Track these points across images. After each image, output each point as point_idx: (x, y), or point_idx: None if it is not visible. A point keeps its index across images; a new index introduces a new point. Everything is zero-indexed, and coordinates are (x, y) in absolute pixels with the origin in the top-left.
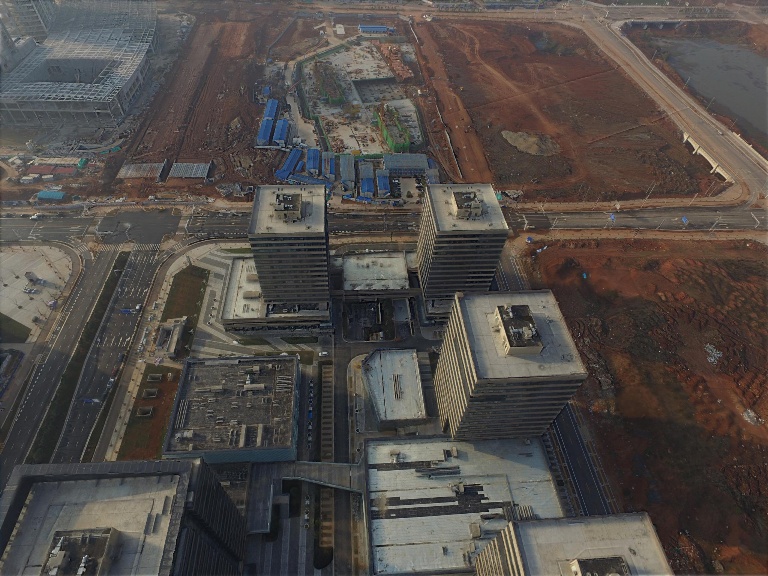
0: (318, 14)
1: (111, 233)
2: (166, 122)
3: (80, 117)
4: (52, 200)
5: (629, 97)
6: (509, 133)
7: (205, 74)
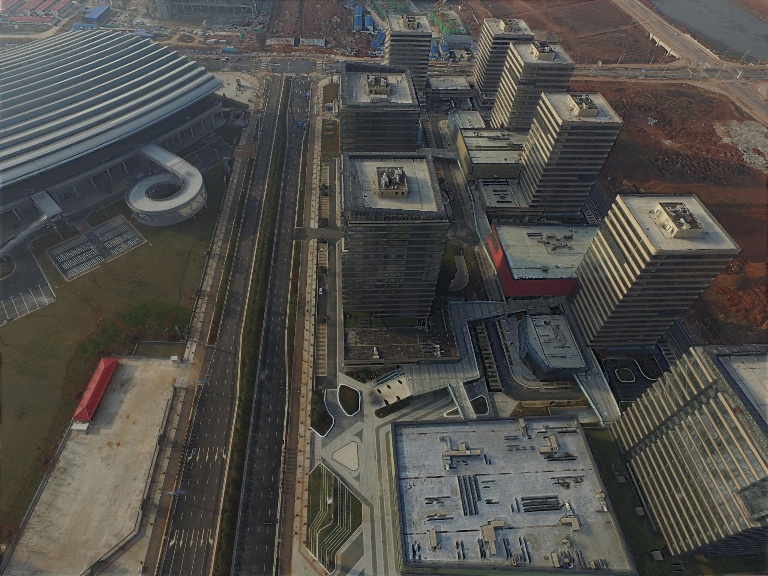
0: None
1: None
2: (286, 18)
3: (227, 13)
4: (231, 52)
5: (613, 14)
6: None
7: None
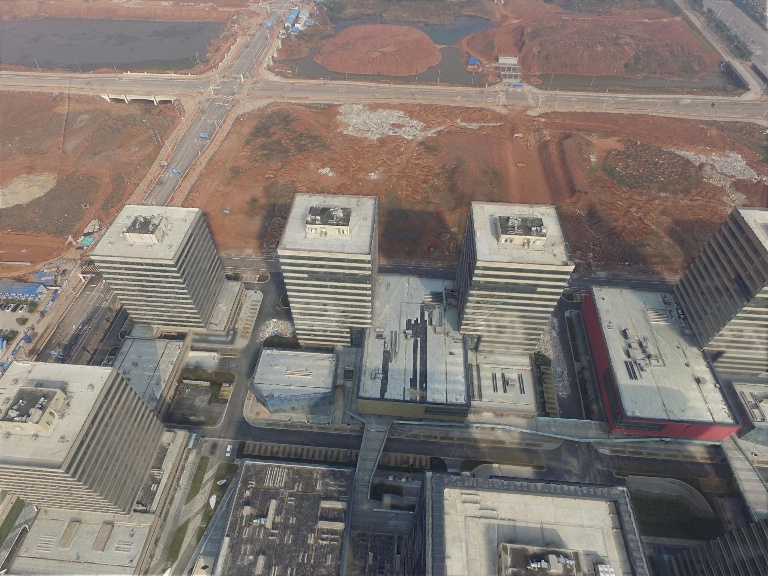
0: None
1: None
2: None
3: None
4: None
5: (17, 103)
6: None
7: None
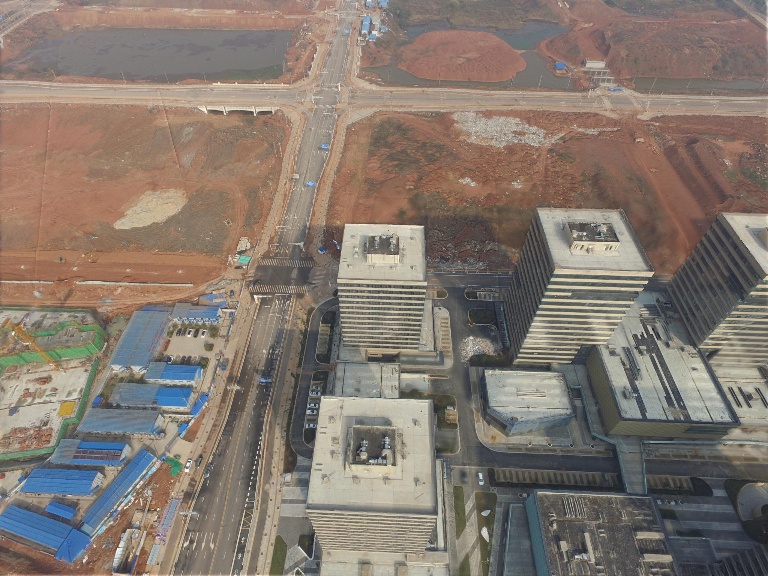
0: None
1: None
2: None
3: None
4: None
5: (113, 117)
6: (123, 222)
7: None
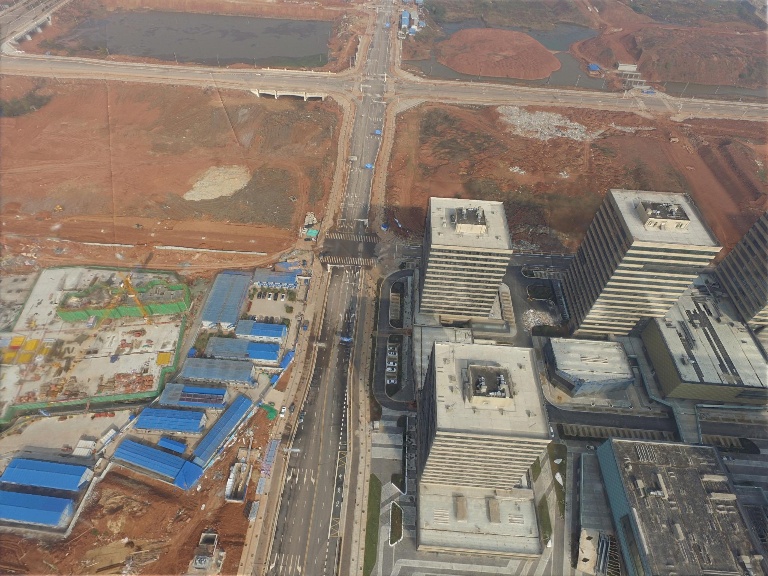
0: None
1: None
2: None
3: None
4: None
5: (169, 96)
6: (193, 194)
7: None
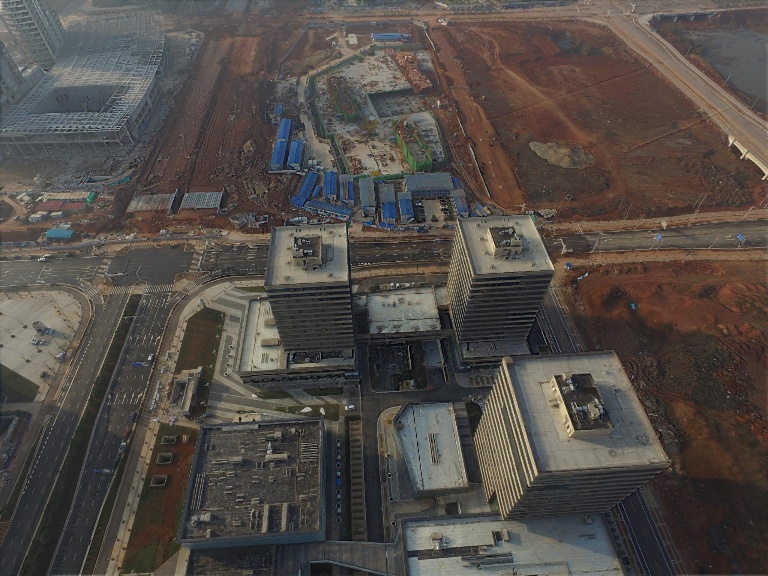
0: (329, 24)
1: (121, 274)
2: (177, 148)
3: (89, 147)
4: (61, 239)
5: (664, 98)
6: (537, 144)
7: (215, 94)
